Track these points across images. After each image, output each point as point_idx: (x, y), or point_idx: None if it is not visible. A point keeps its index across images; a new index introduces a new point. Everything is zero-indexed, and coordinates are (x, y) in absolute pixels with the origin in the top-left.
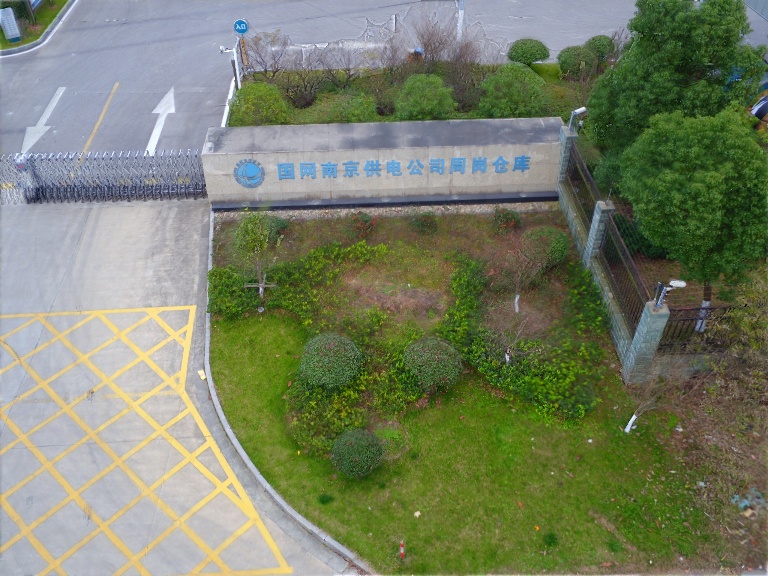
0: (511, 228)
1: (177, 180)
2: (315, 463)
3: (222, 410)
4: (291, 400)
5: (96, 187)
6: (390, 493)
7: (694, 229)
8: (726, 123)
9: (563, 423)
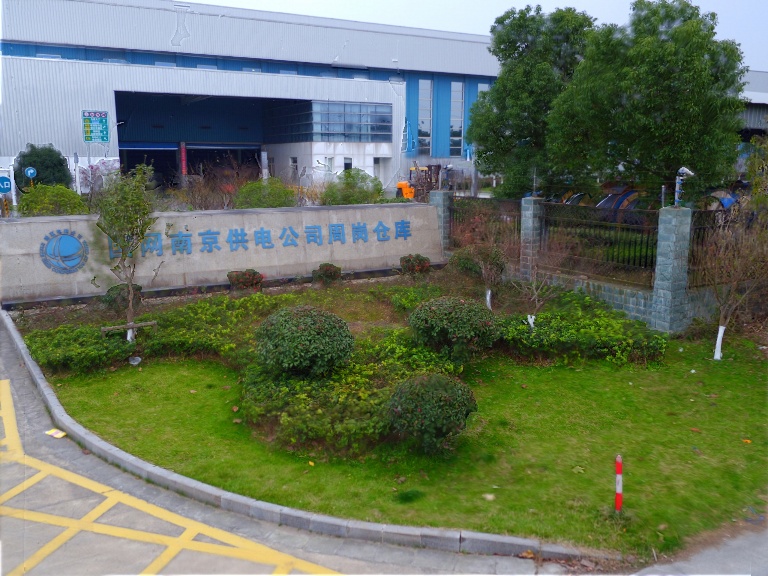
0: (426, 272)
1: None
2: (351, 468)
3: (124, 451)
4: (260, 403)
5: None
6: (510, 463)
7: (699, 71)
8: (664, 4)
9: (647, 366)
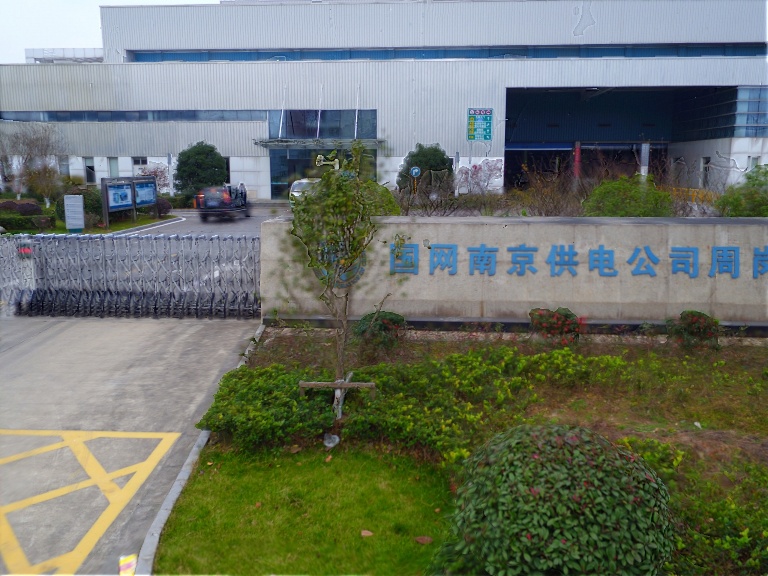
0: None
1: (215, 286)
2: None
3: None
4: None
5: (81, 291)
6: None
7: None
8: None
9: None
